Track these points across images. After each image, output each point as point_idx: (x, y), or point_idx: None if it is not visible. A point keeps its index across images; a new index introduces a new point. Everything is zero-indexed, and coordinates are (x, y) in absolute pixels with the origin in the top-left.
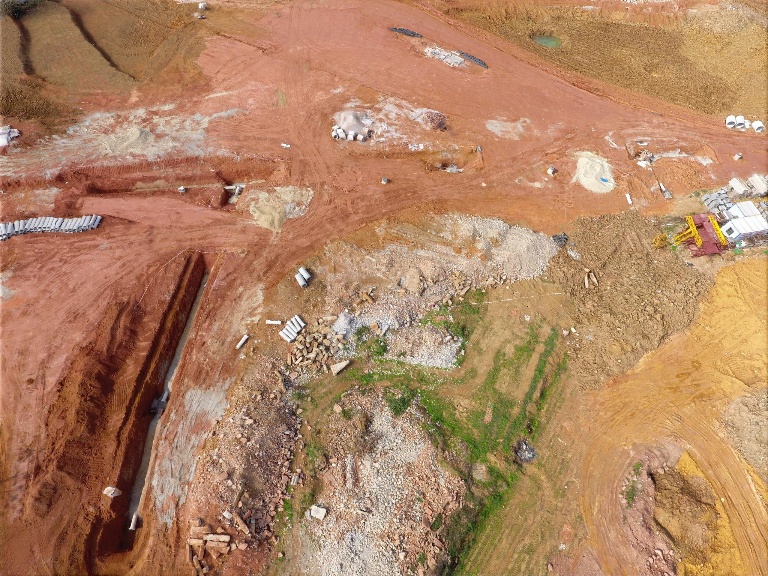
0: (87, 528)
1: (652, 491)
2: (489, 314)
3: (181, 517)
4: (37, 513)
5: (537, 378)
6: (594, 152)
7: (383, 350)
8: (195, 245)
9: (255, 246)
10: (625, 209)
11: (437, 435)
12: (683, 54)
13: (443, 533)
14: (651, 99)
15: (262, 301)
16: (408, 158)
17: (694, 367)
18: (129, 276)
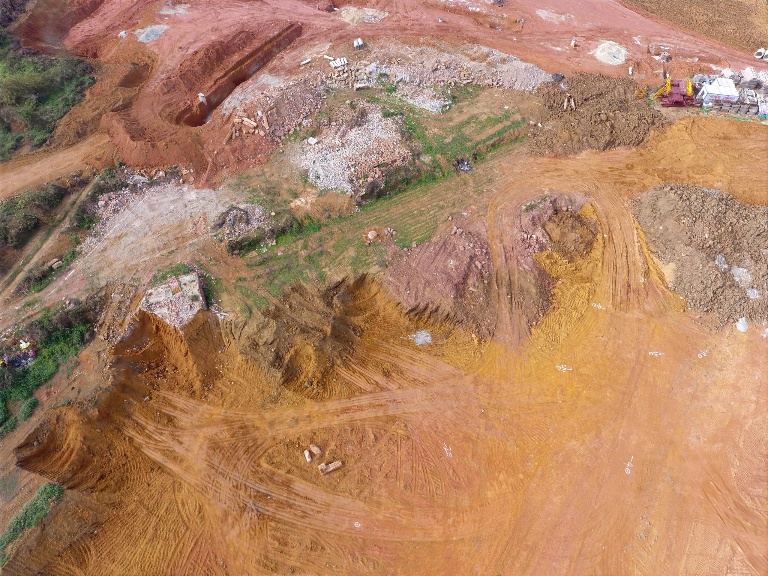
0: (183, 108)
1: (550, 212)
2: (479, 98)
3: (234, 113)
4: (161, 91)
5: (495, 135)
6: (618, 43)
7: (393, 89)
8: (299, 21)
9: (336, 28)
10: (624, 76)
11: (406, 132)
12: (750, 19)
13: (385, 172)
14: (695, 33)
15: (327, 49)
16: (465, 15)
17: (627, 167)
18: (254, 22)
